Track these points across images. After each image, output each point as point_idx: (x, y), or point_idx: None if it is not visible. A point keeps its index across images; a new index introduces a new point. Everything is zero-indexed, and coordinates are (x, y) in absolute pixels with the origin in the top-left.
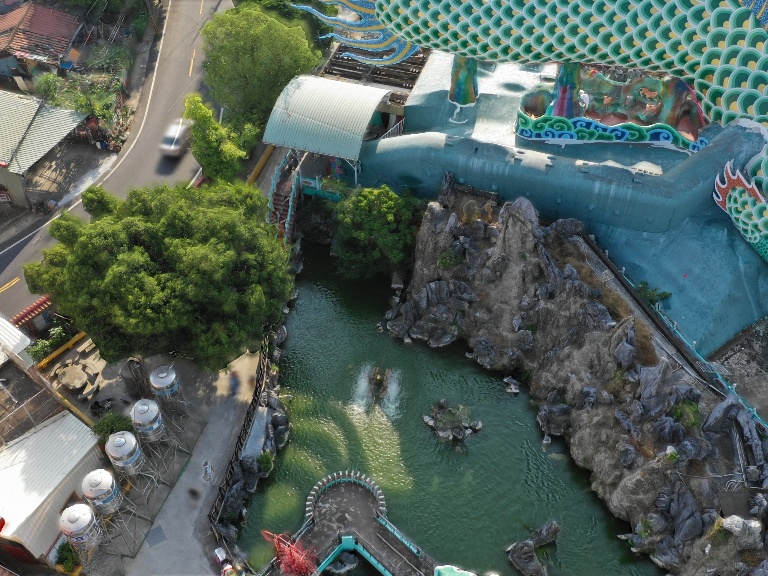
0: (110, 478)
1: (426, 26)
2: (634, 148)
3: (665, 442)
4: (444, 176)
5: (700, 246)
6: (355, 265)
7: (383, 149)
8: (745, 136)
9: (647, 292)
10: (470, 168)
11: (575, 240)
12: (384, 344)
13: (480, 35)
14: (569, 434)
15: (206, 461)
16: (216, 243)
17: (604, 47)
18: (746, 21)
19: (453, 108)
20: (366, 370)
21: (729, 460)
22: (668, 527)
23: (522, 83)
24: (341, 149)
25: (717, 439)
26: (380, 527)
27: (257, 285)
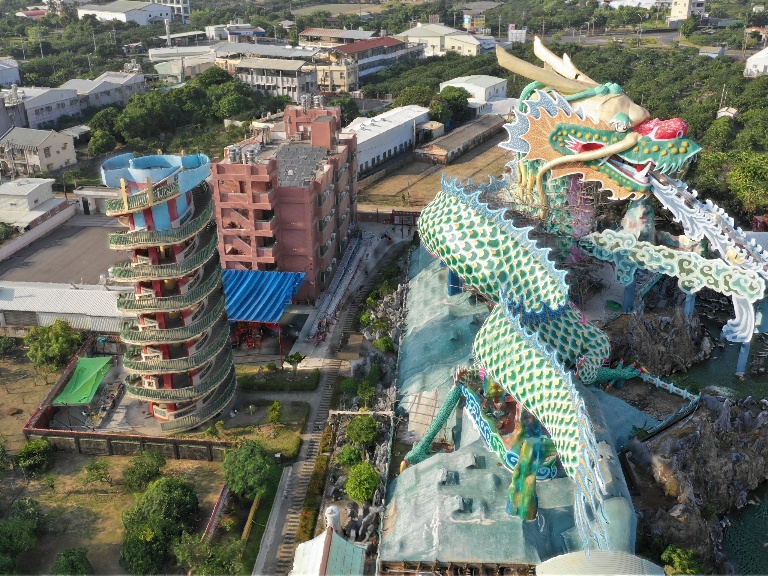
0: None
1: None
2: None
3: None
4: None
5: None
6: None
7: None
8: None
9: (645, 431)
10: None
11: None
12: None
13: None
14: None
15: None
16: None
17: None
18: None
19: None
20: None
21: None
22: None
23: (483, 479)
24: None
25: None
26: None
27: None
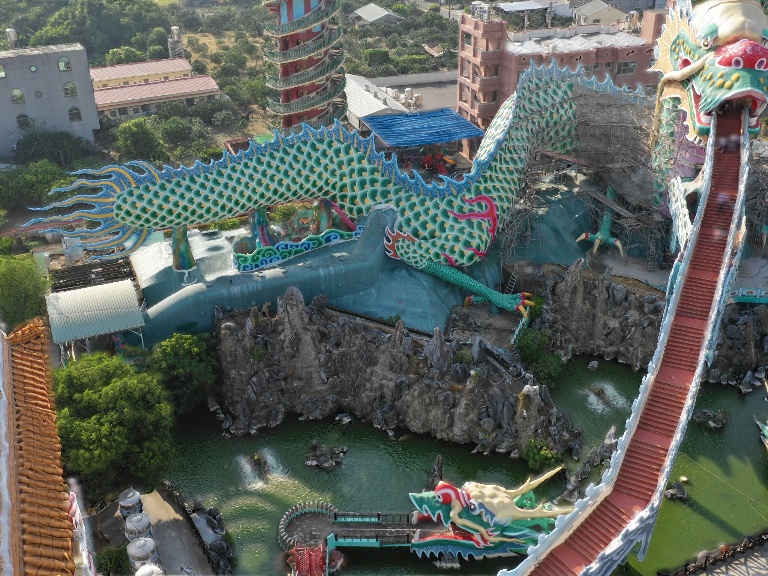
0: (156, 567)
1: (161, 209)
2: (320, 251)
3: (463, 379)
4: (215, 310)
5: (397, 284)
6: (183, 399)
7: (156, 313)
8: (384, 213)
9: (388, 319)
10: (233, 295)
11: None
12: (239, 442)
13: (203, 202)
14: (402, 420)
15: (180, 567)
16: (119, 380)
17: (281, 189)
18: (350, 150)
19: (182, 275)
20: (242, 460)
21: (498, 373)
22: (494, 426)
23: None
24: (127, 322)
25: None
26: (341, 525)
27: (159, 404)
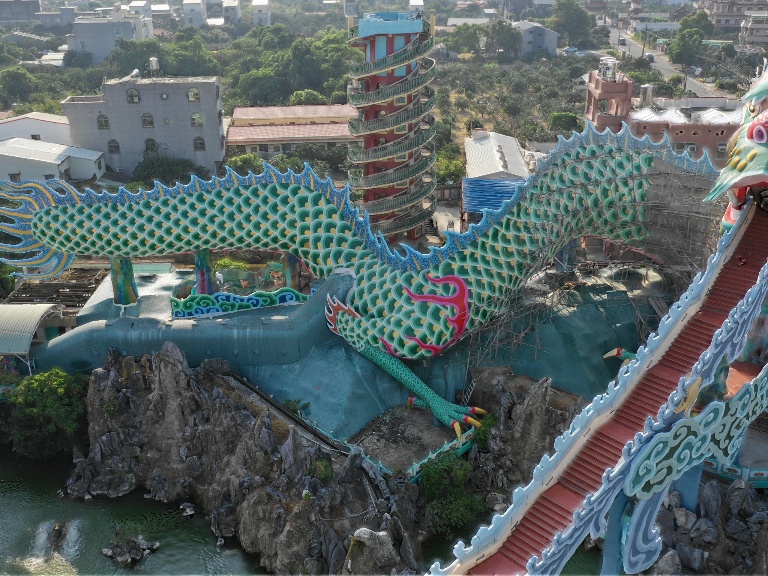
0: None
1: (75, 233)
2: (268, 310)
3: None
4: (108, 352)
5: (326, 364)
6: (31, 441)
7: (53, 343)
8: (340, 278)
9: None
10: (129, 340)
11: (226, 379)
12: (64, 504)
13: (120, 233)
14: (238, 530)
15: None
16: None
17: (222, 232)
18: (320, 201)
19: (118, 310)
20: (45, 526)
21: (363, 501)
22: (324, 571)
23: None
24: (12, 346)
25: (352, 488)
26: None
27: None
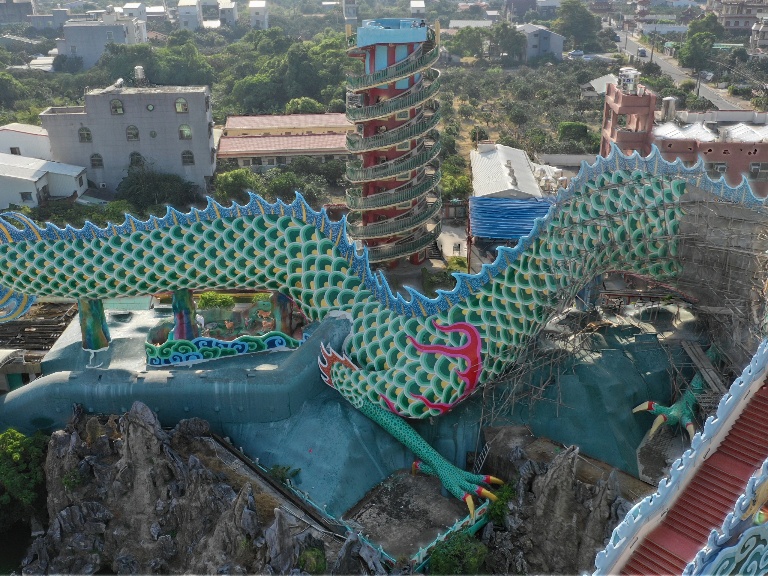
0: None
1: (34, 274)
2: (255, 357)
3: None
4: (72, 409)
5: (319, 422)
6: None
7: (11, 398)
8: (335, 323)
9: (276, 471)
10: (96, 395)
11: (206, 441)
12: None
13: (85, 273)
14: None
15: None
16: None
17: (202, 270)
18: (313, 235)
19: (88, 355)
20: None
21: None
22: None
23: None
24: None
25: None
26: None
27: None
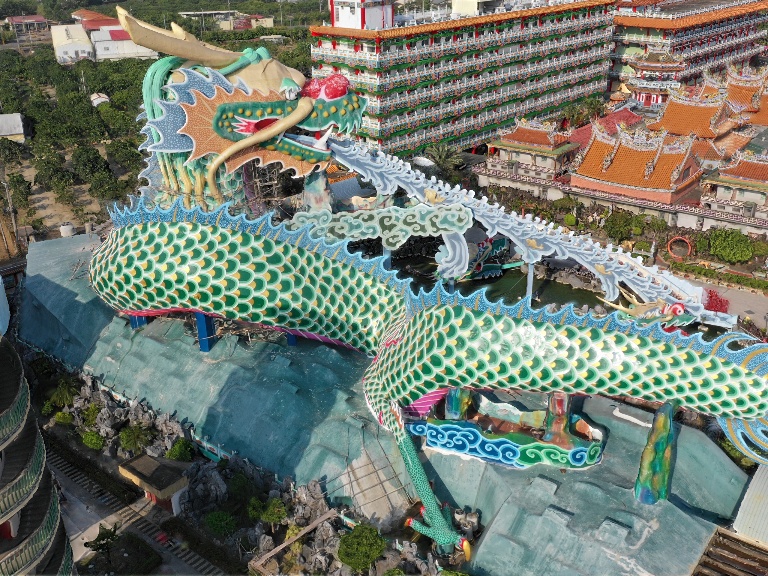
0: None
1: None
2: None
3: None
4: None
5: None
6: None
7: None
8: None
9: None
10: None
11: None
12: None
13: None
14: None
15: None
16: None
17: None
18: None
19: None
20: None
21: None
22: None
23: (580, 493)
24: None
25: None
26: None
27: None
